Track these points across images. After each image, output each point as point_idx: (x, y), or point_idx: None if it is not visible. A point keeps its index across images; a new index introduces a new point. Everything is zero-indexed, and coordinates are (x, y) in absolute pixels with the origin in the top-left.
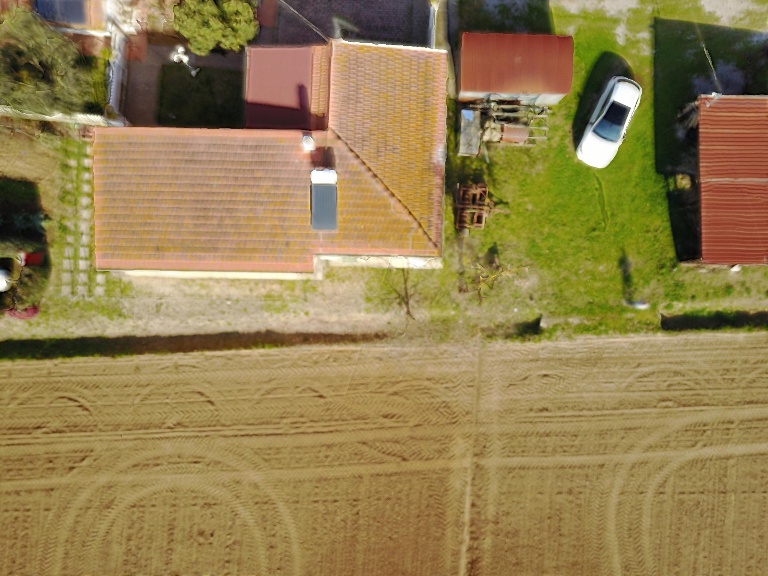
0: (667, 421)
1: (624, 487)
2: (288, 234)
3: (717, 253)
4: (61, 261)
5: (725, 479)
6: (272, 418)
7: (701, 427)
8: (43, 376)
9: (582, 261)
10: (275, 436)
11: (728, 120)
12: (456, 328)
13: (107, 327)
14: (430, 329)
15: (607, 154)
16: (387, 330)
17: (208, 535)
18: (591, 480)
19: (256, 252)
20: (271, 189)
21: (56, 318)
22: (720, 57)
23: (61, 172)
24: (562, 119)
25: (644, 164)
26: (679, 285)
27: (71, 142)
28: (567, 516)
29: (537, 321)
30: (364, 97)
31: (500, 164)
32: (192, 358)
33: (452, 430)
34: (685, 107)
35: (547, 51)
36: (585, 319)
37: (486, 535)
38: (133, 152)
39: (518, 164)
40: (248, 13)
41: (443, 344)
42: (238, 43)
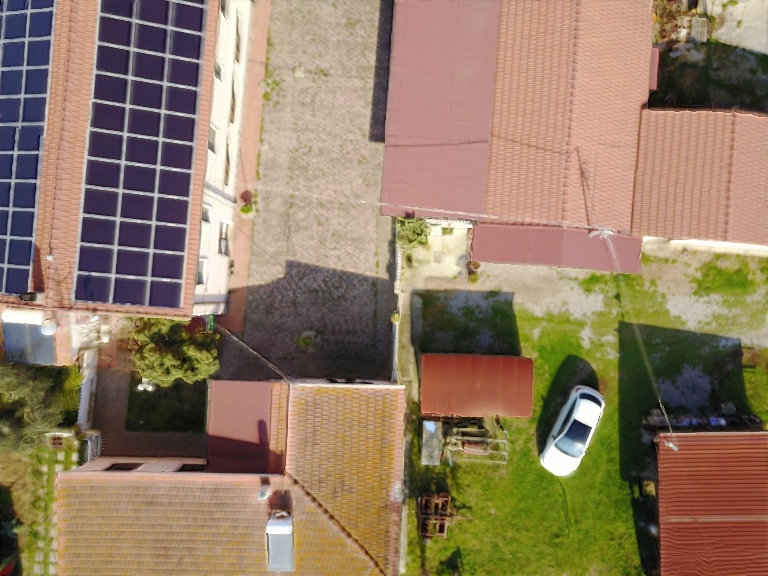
0: None
1: None
2: (246, 572)
3: None
4: (32, 565)
5: None
6: None
7: None
8: None
9: (546, 567)
10: None
11: (688, 457)
12: None
13: None
14: None
15: (570, 465)
16: None
17: None
18: None
19: None
20: (229, 530)
21: None
22: (685, 362)
23: (32, 476)
24: (526, 422)
25: (608, 470)
26: None
27: (42, 447)
28: None
29: None
30: (321, 438)
31: (463, 468)
32: None
33: None
34: (650, 414)
35: (506, 377)
36: None
37: None
38: (95, 495)
39: (481, 468)
40: (207, 358)
41: None
42: (199, 377)
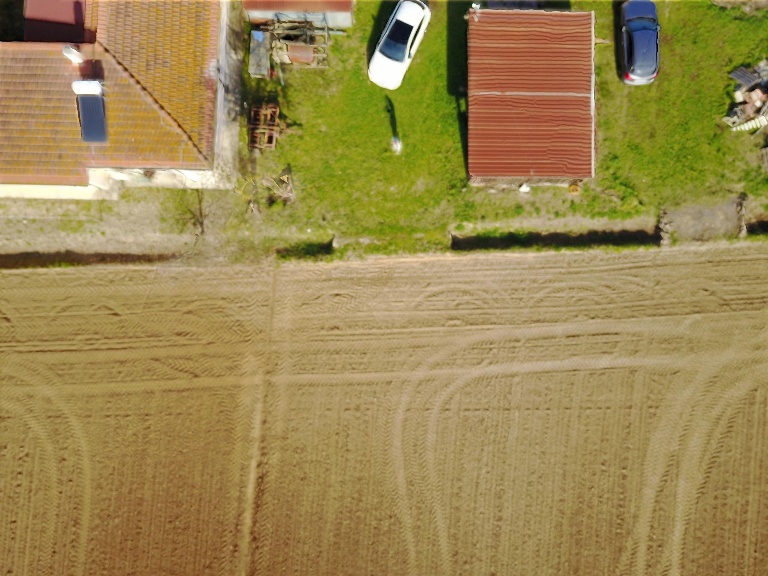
0: (455, 339)
1: (411, 404)
2: (60, 147)
3: (483, 166)
4: None
5: (510, 396)
6: (67, 335)
7: (488, 345)
8: None
9: (374, 182)
10: (69, 352)
11: (497, 35)
12: (251, 249)
13: None
14: (226, 249)
15: (396, 75)
16: (184, 250)
17: (2, 447)
18: (379, 397)
19: (29, 164)
20: (42, 102)
21: None
22: None
23: None
24: (356, 42)
25: (436, 86)
26: (469, 206)
27: None
28: (355, 432)
29: (330, 242)
30: (133, 11)
31: (294, 86)
32: None
33: (245, 348)
34: None
35: None
36: (375, 239)
37: (276, 450)
38: None
39: (312, 86)
40: None
41: (238, 264)
42: None
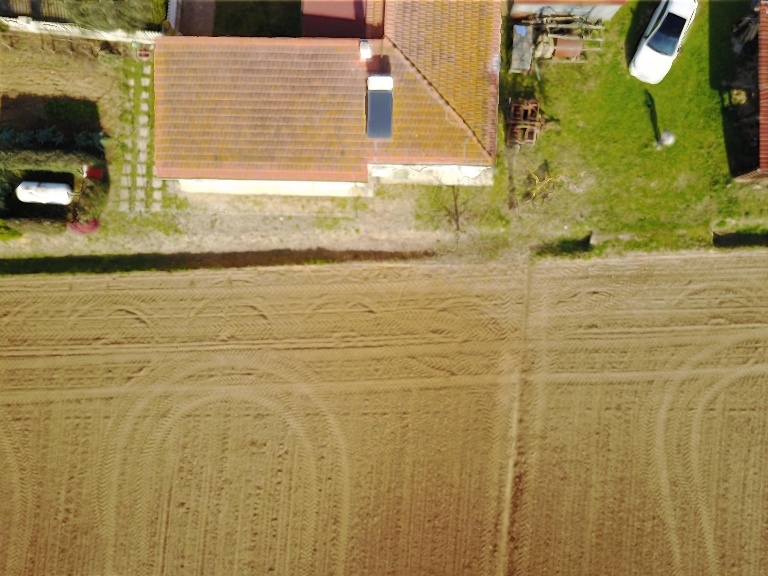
0: (718, 338)
1: (674, 403)
2: (343, 143)
3: None
4: (119, 177)
5: None
6: (323, 332)
7: (753, 344)
8: (102, 289)
9: (633, 178)
10: (326, 350)
11: None
12: (505, 246)
13: (163, 243)
14: (479, 247)
15: (660, 69)
16: (436, 248)
17: (261, 444)
18: (640, 396)
19: (312, 161)
20: (327, 98)
21: (114, 233)
22: None
23: (118, 90)
24: (614, 36)
25: (698, 80)
26: (732, 202)
27: (128, 61)
28: (616, 431)
29: (587, 239)
30: (419, 6)
31: (551, 81)
32: (245, 273)
33: (501, 346)
34: (741, 22)
35: None
36: (636, 236)
37: (534, 449)
38: (192, 61)
39: (569, 81)
40: None
41: (492, 261)
42: None
